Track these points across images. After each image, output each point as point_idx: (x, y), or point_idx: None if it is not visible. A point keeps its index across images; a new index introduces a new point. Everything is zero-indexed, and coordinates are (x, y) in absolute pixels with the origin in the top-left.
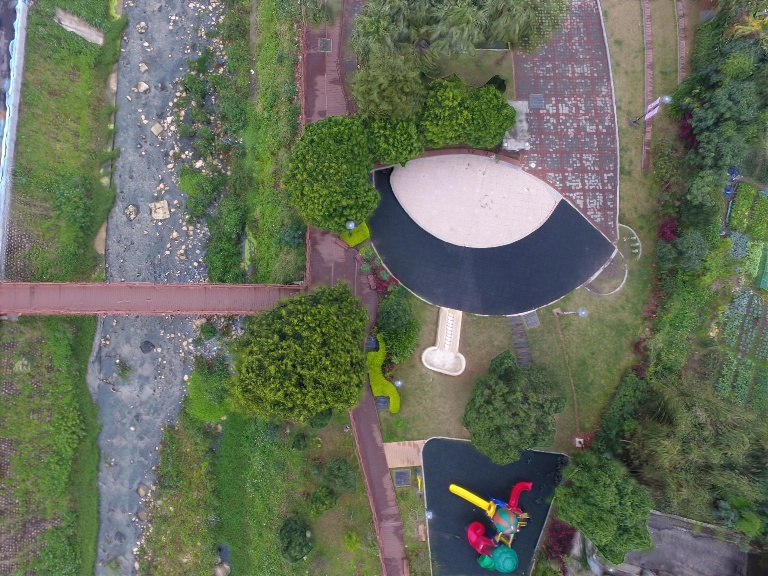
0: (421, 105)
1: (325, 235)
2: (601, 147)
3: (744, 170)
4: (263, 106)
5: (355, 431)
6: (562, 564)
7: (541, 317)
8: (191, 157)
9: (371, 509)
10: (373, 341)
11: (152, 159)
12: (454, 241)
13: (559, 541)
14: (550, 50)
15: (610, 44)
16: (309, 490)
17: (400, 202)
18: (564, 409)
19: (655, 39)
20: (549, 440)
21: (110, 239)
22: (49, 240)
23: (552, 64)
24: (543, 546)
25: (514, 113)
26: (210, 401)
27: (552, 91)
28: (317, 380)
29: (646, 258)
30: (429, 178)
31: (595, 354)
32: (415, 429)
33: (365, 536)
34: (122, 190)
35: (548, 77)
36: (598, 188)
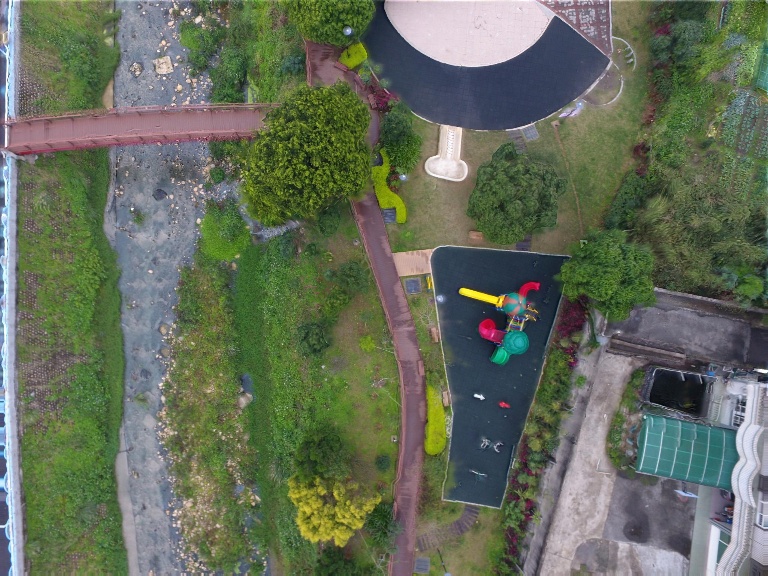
0: None
1: (324, 60)
2: None
3: None
4: None
5: (364, 238)
6: (572, 353)
7: (540, 130)
8: (190, 14)
9: (384, 310)
10: (377, 158)
11: (153, 18)
12: (450, 62)
13: (568, 332)
14: None
15: None
16: (323, 303)
17: (395, 27)
18: (567, 213)
19: None
20: (552, 216)
21: (117, 96)
22: (59, 92)
23: None
24: (553, 343)
25: None
26: (223, 240)
27: None
28: (323, 157)
29: (641, 68)
30: (422, 3)
31: (595, 160)
32: (422, 239)
33: (380, 341)
34: (126, 49)
35: None
36: (590, 4)
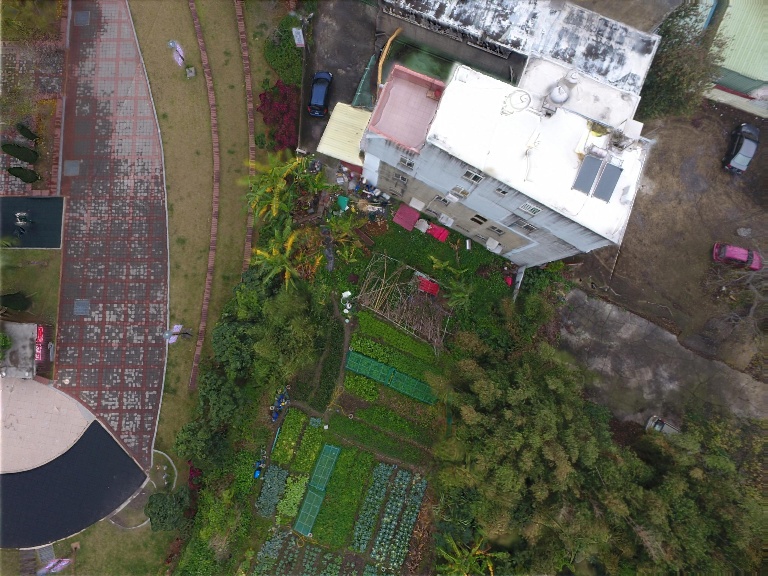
0: None
1: None
2: (147, 361)
3: (297, 393)
4: None
5: None
6: None
7: (57, 552)
8: None
9: None
10: None
11: None
12: None
13: None
14: (105, 249)
15: (172, 242)
16: None
17: None
18: None
19: (221, 238)
20: None
21: None
22: None
23: (105, 265)
24: None
25: (5, 344)
26: None
27: (100, 296)
28: None
29: (179, 489)
30: None
31: None
32: None
33: None
34: None
35: (99, 280)
36: (137, 408)
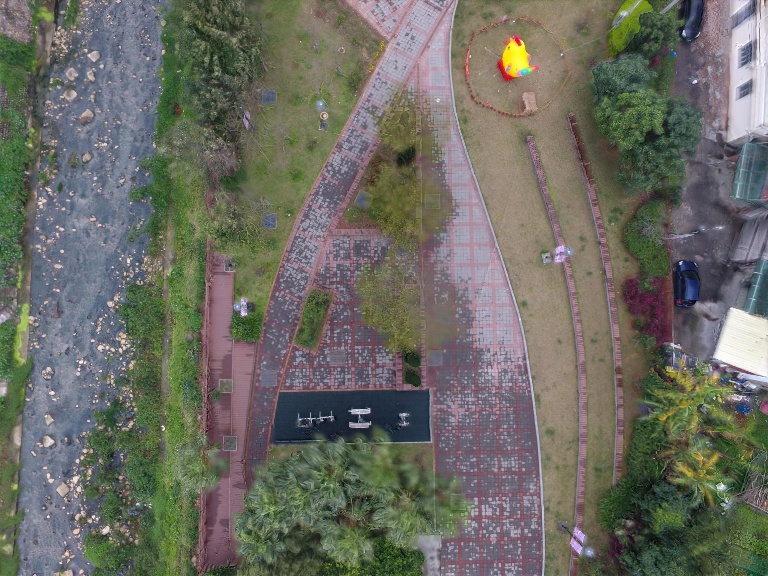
0: (318, 566)
1: None
2: (525, 555)
3: None
4: (169, 484)
5: None
6: None
7: None
8: (98, 522)
9: None
10: None
11: (57, 522)
12: None
13: None
14: (475, 441)
15: (541, 434)
16: None
17: None
18: None
19: (591, 429)
20: None
21: None
22: None
23: (477, 458)
24: None
25: None
26: None
27: (475, 490)
28: None
29: None
30: None
31: None
32: None
33: None
34: (26, 557)
35: (472, 473)
36: None
